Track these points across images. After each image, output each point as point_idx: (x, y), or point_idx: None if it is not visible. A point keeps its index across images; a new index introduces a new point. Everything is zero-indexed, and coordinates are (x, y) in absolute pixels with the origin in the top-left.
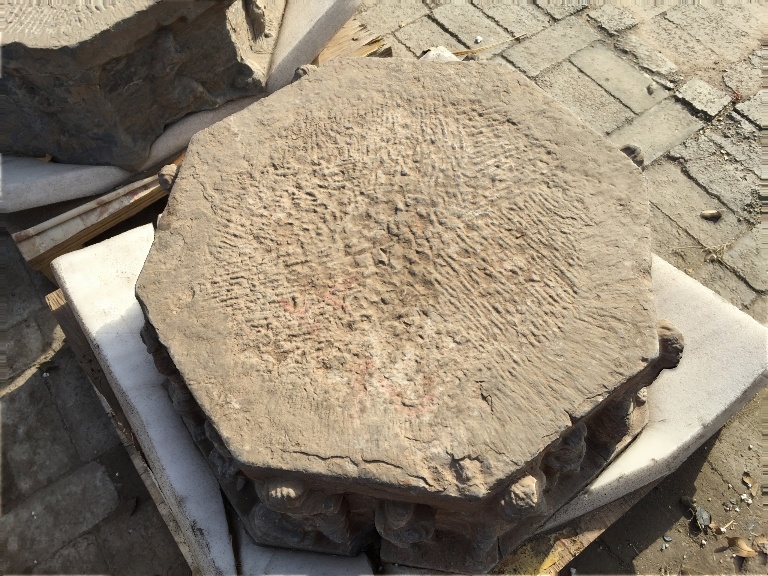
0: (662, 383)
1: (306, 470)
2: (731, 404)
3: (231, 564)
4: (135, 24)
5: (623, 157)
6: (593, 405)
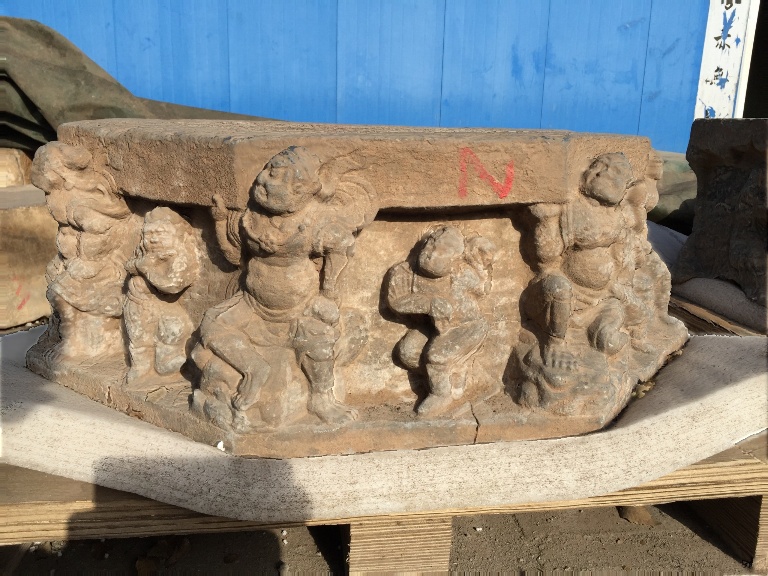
0: (34, 377)
1: None
2: None
3: None
4: (738, 129)
5: None
6: None
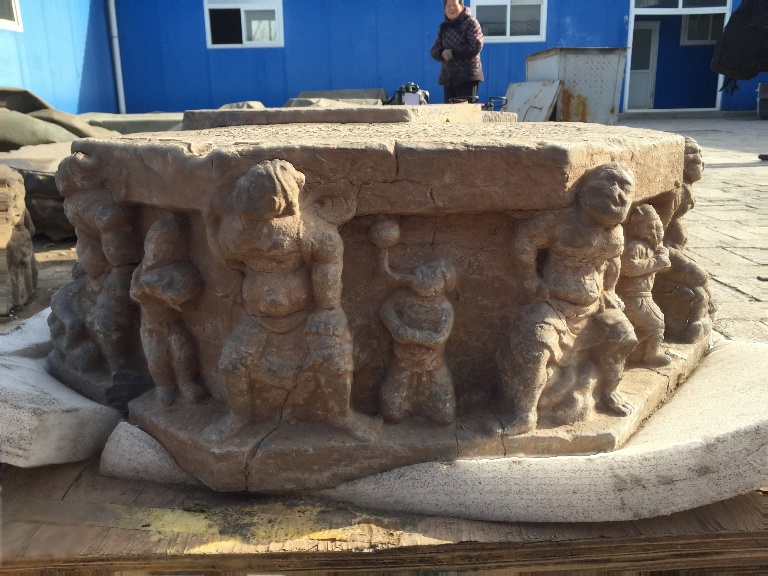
0: (671, 417)
1: (109, 141)
2: None
3: (3, 349)
4: (321, 116)
5: None
6: (435, 146)
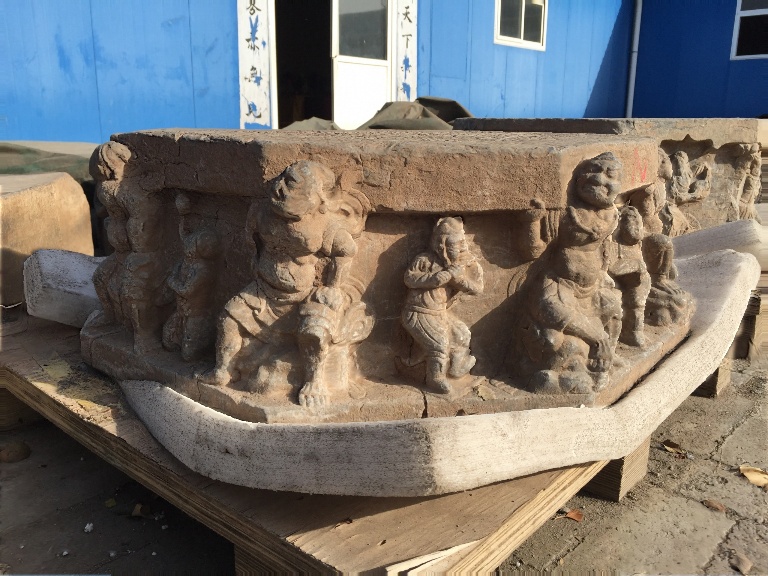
0: None
1: None
2: (293, 432)
3: None
4: (531, 126)
5: (575, 145)
6: (197, 137)
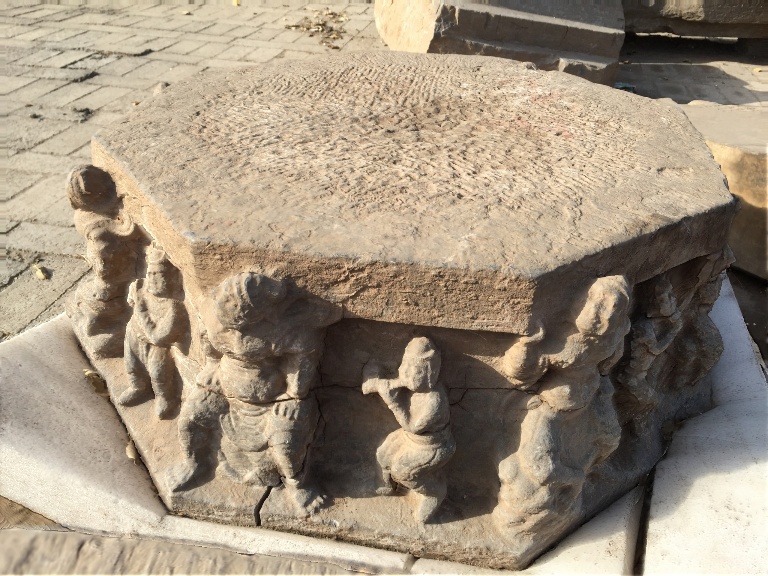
0: None
1: None
2: None
3: None
4: None
5: None
6: None
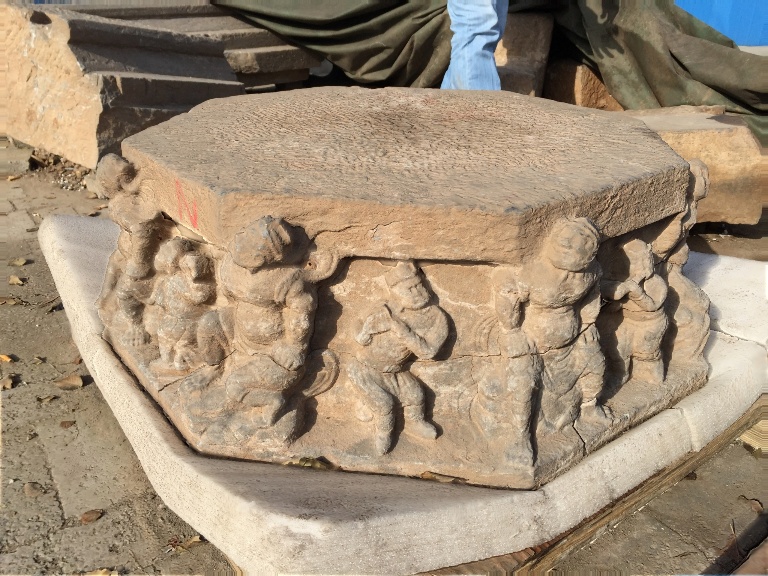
0: None
1: None
2: None
3: None
4: None
5: (135, 146)
6: None
